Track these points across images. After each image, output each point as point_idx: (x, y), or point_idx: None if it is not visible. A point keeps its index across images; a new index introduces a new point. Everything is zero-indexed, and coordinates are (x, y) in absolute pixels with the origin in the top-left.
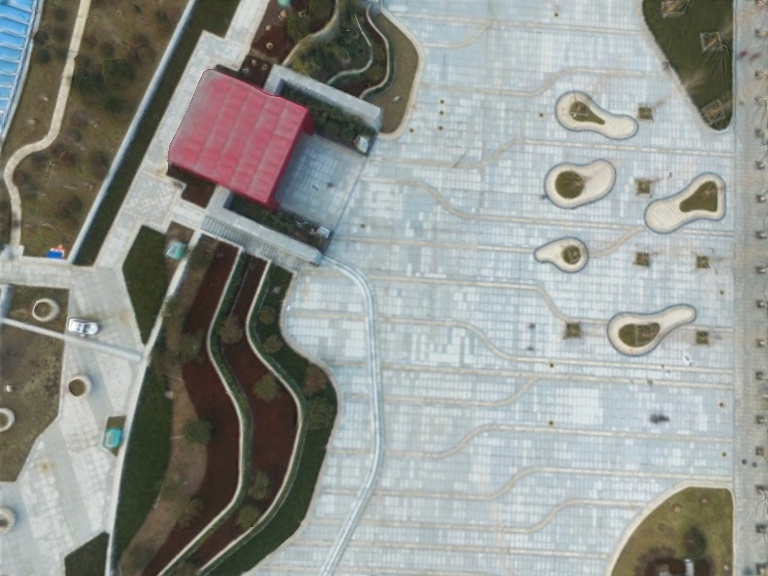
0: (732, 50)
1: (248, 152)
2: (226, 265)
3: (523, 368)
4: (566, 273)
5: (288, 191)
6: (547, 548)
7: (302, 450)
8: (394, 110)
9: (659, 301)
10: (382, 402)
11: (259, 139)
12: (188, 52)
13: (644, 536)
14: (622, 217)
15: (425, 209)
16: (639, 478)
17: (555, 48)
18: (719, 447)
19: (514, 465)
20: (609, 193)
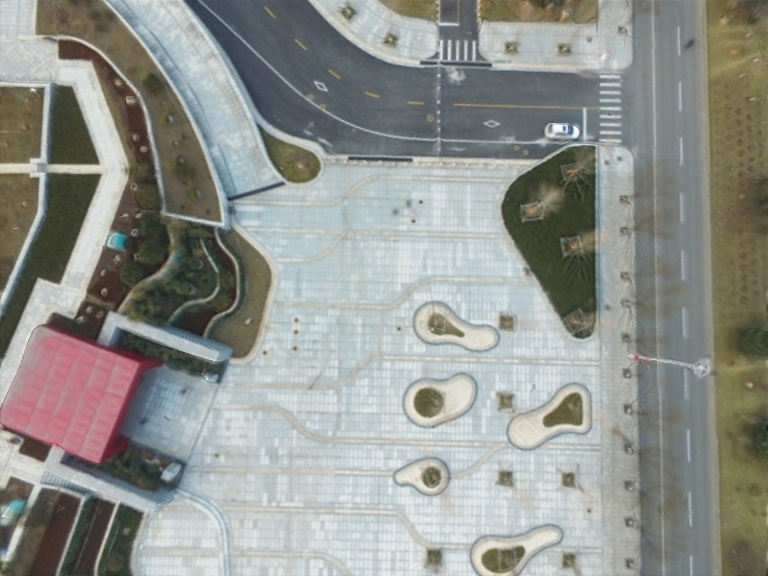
0: (595, 253)
1: (79, 411)
2: (68, 518)
3: None
4: (427, 496)
5: (139, 424)
6: None
7: None
8: (246, 333)
9: (524, 522)
10: None
11: (90, 397)
12: (23, 301)
13: None
14: (484, 434)
15: (280, 435)
16: None
17: (413, 256)
18: None
19: None
20: (470, 409)
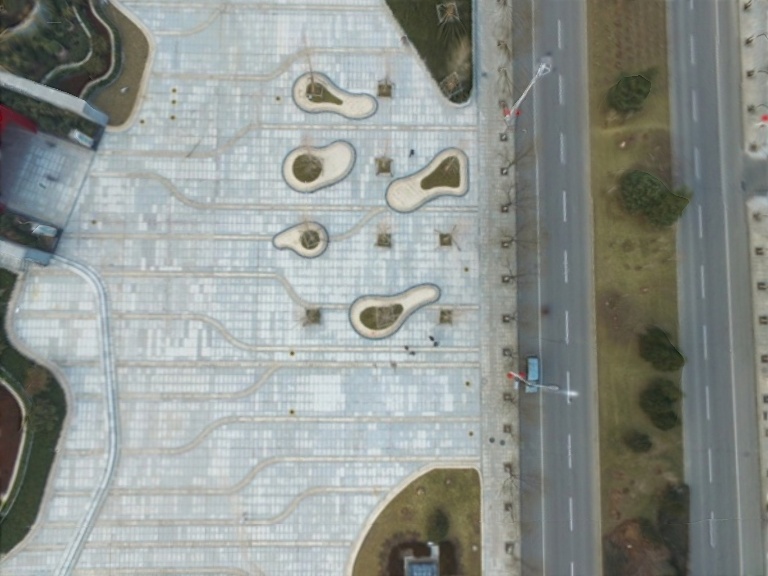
0: (471, 21)
1: None
2: None
3: (263, 358)
4: (306, 259)
5: (14, 191)
6: (290, 539)
7: (29, 454)
8: (122, 102)
9: (402, 282)
10: (117, 400)
11: None
12: None
13: (388, 521)
14: (363, 198)
15: (158, 201)
16: (383, 463)
17: (292, 29)
18: (466, 427)
19: (254, 457)
20: (349, 174)
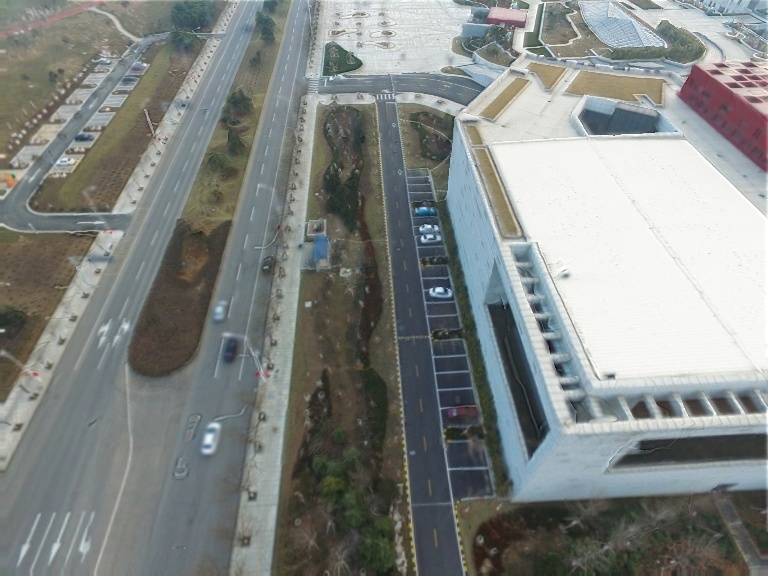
0: None
1: None
2: None
3: None
4: None
5: None
6: None
7: None
8: None
9: (352, 19)
10: None
11: None
12: None
13: None
14: None
15: None
16: None
17: None
18: (332, 3)
19: None
20: None
